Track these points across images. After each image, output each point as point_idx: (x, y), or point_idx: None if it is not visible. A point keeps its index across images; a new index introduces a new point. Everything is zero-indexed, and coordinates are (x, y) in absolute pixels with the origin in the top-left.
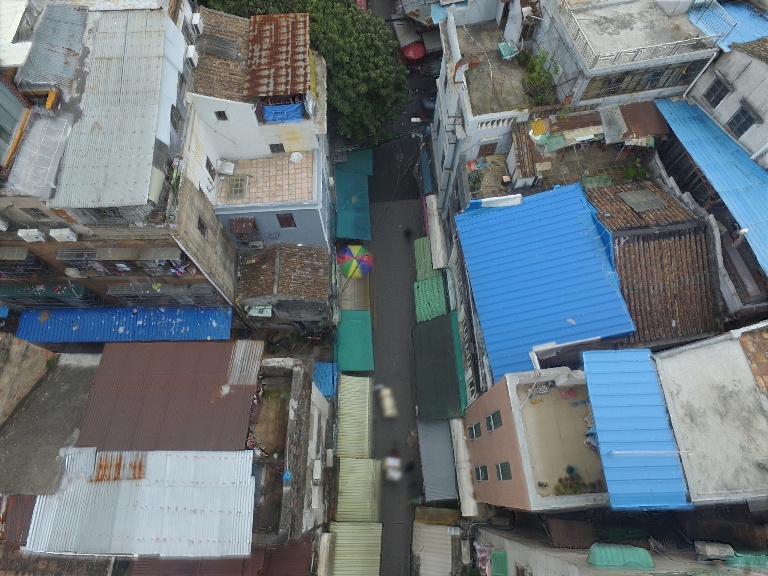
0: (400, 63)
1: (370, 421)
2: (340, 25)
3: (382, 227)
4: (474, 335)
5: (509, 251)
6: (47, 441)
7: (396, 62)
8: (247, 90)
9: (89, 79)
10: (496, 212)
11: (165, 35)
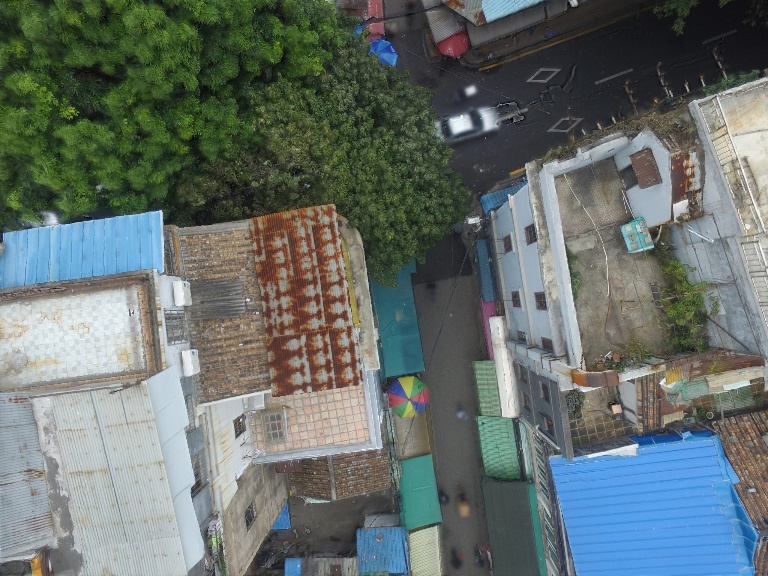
0: (432, 56)
1: (442, 568)
2: (375, 172)
3: (430, 318)
4: (567, 570)
5: (619, 517)
6: None
7: (425, 49)
8: (275, 383)
9: (73, 507)
10: (603, 462)
11: (157, 425)
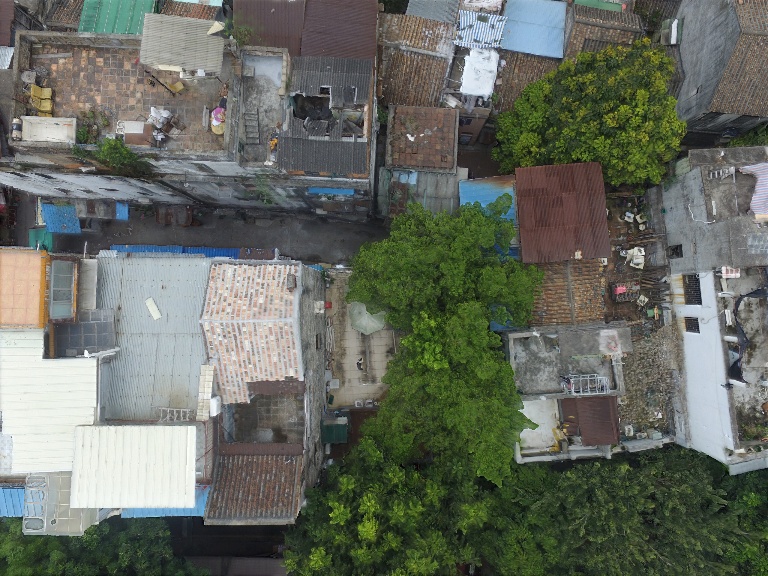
0: None
1: None
2: None
3: None
4: None
5: None
6: (7, 97)
7: None
8: None
9: None
10: None
11: None
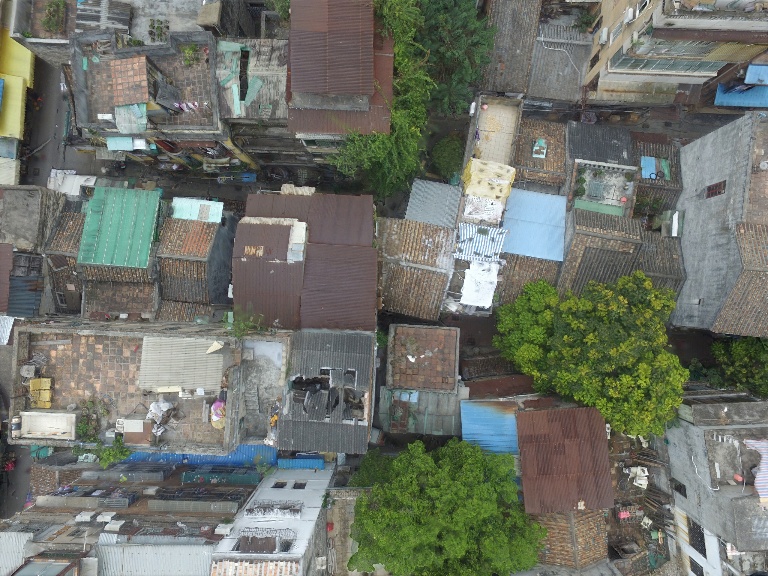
0: None
1: None
2: None
3: None
4: None
5: None
6: (7, 373)
7: None
8: None
9: None
10: None
11: None
